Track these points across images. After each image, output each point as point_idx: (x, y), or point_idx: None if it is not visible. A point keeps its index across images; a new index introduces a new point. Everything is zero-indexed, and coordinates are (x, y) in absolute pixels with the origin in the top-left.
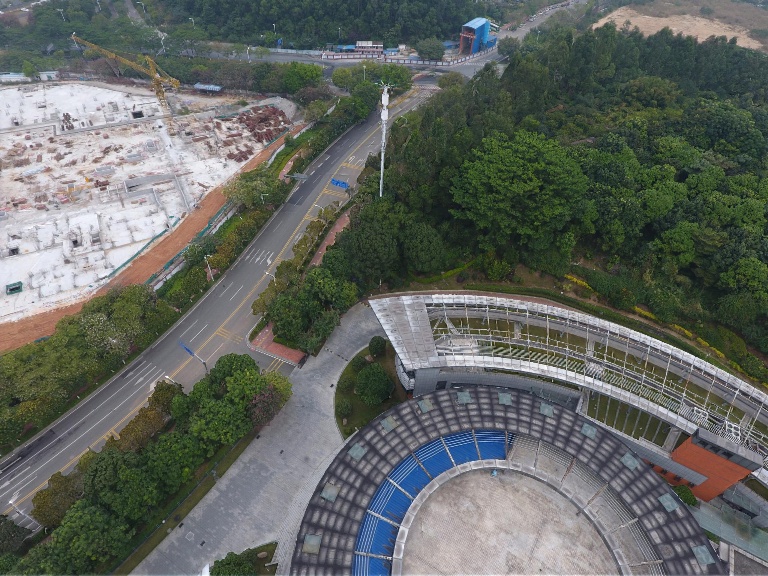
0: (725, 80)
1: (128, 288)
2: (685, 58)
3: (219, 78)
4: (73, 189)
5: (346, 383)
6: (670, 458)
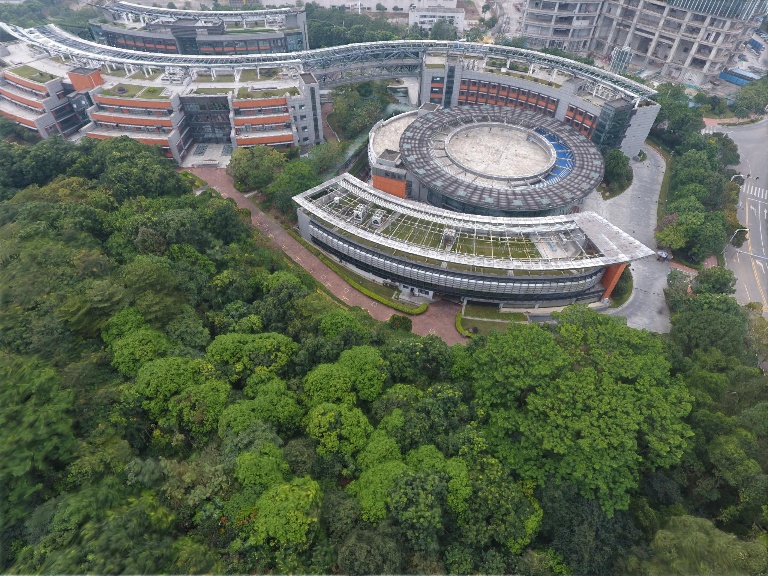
0: None
1: None
2: None
3: None
4: None
5: None
6: None
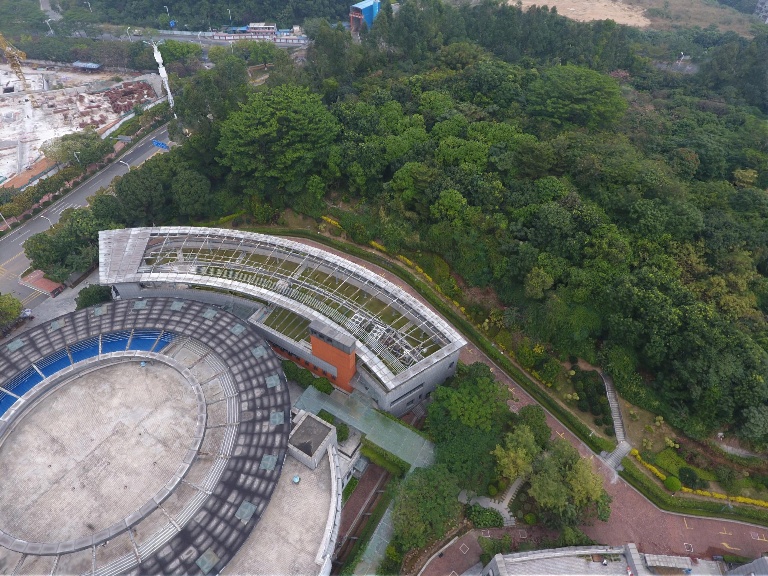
0: (551, 48)
1: None
2: (509, 27)
3: (96, 56)
4: None
5: None
6: (311, 353)
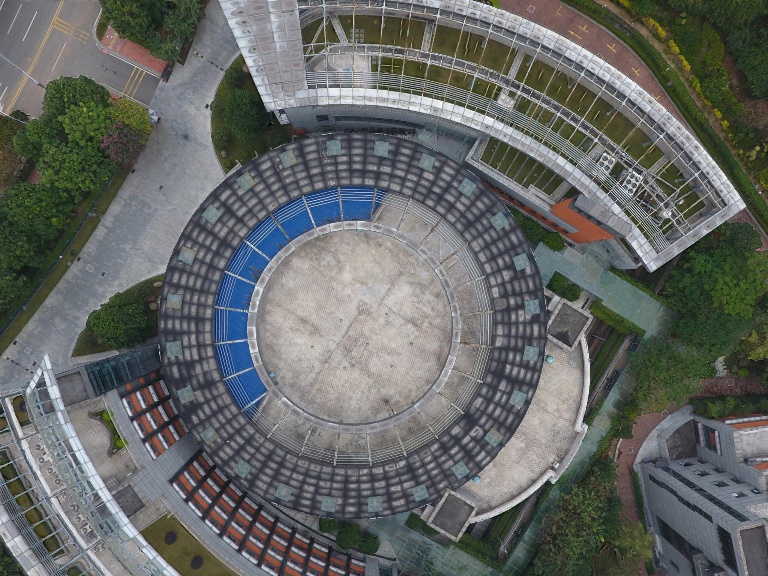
0: None
1: None
2: None
3: None
4: None
5: (218, 108)
6: (550, 211)
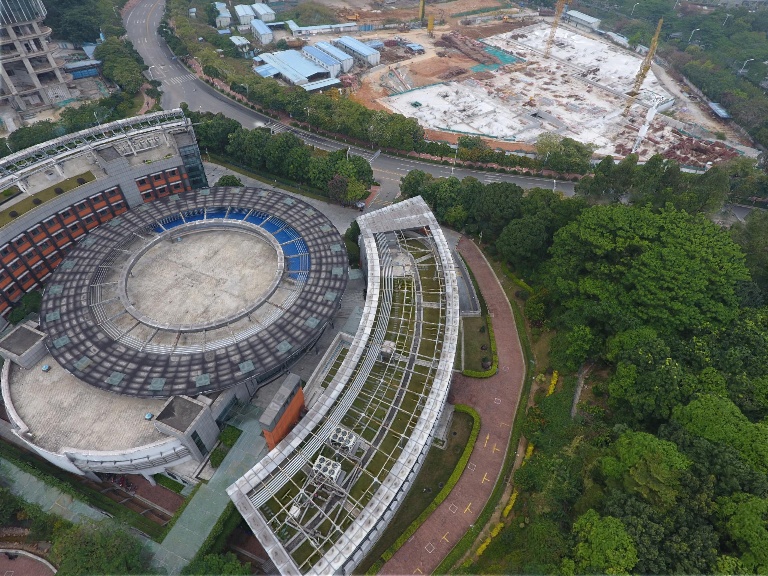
0: None
1: (412, 120)
2: None
3: (735, 107)
4: (514, 95)
5: None
6: None
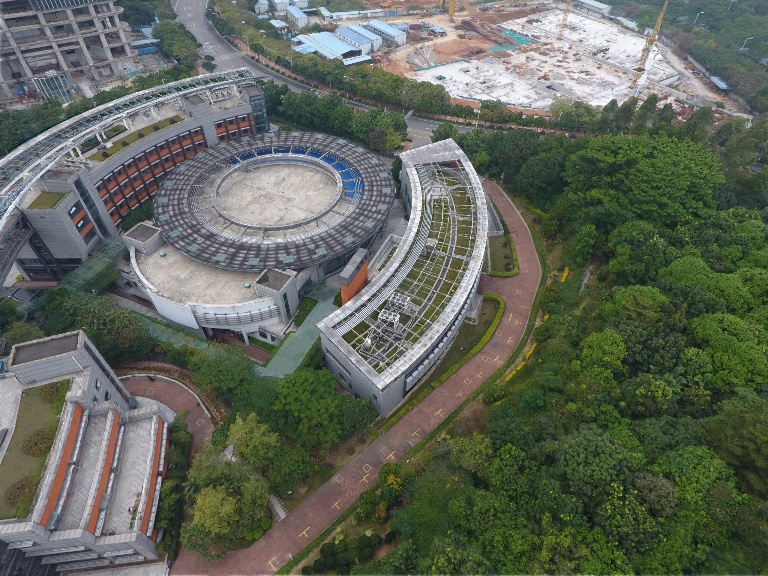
0: None
1: (439, 86)
2: None
3: (734, 79)
4: None
5: None
6: None
